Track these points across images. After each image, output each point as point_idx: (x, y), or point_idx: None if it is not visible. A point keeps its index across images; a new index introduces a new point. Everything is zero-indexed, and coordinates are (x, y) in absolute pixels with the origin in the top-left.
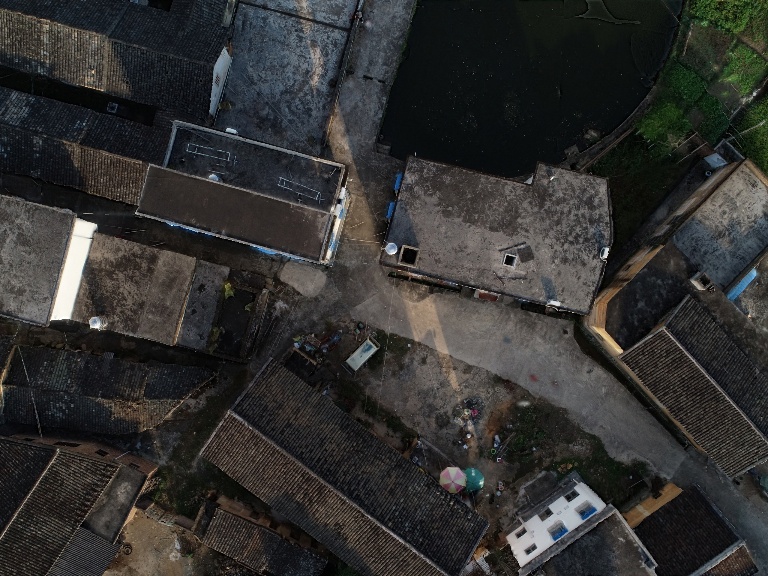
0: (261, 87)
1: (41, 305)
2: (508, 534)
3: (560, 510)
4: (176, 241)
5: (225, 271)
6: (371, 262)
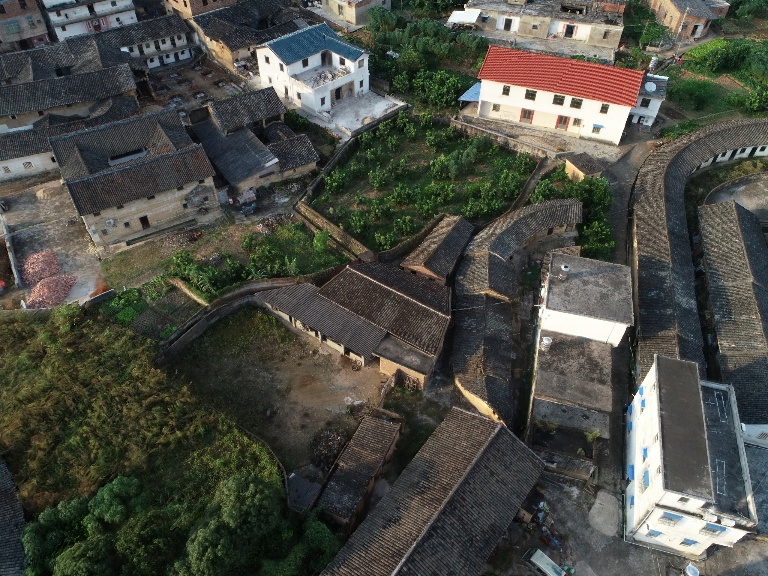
0: None
1: (561, 305)
2: None
3: None
4: None
5: (605, 435)
6: None
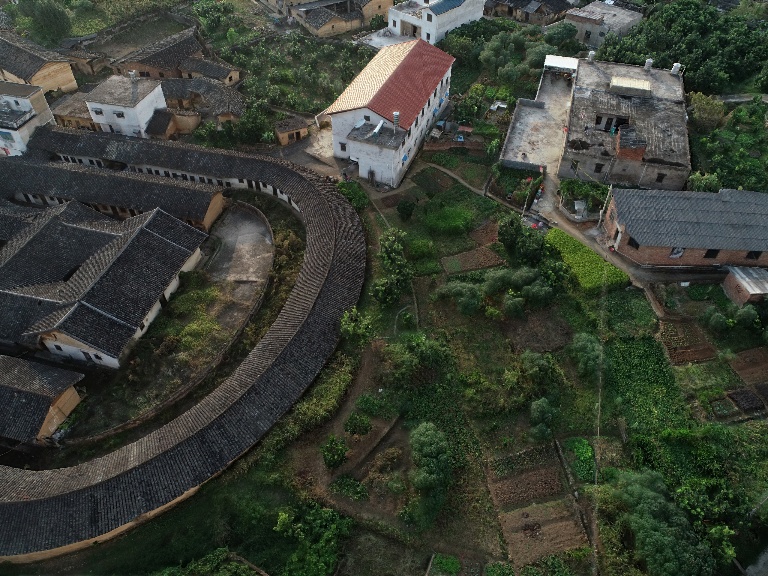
0: None
1: (112, 79)
2: None
3: None
4: None
5: None
6: None
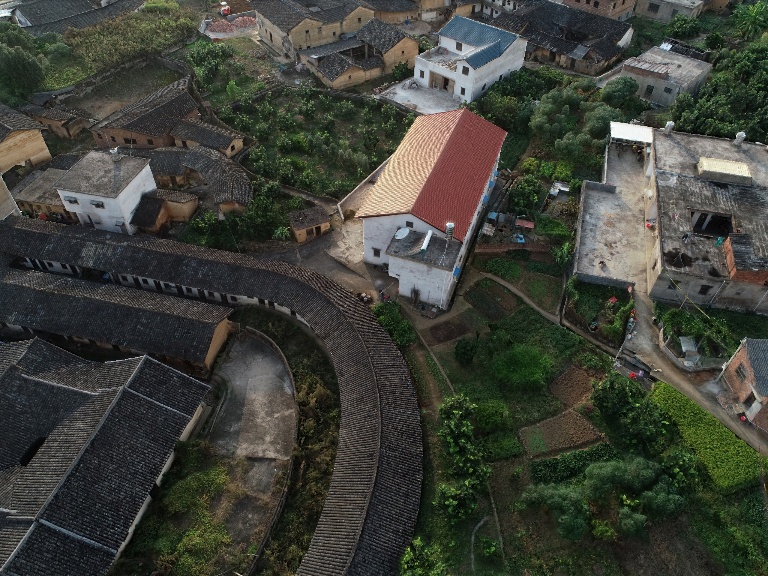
0: None
1: (90, 157)
2: None
3: None
4: None
5: None
6: None
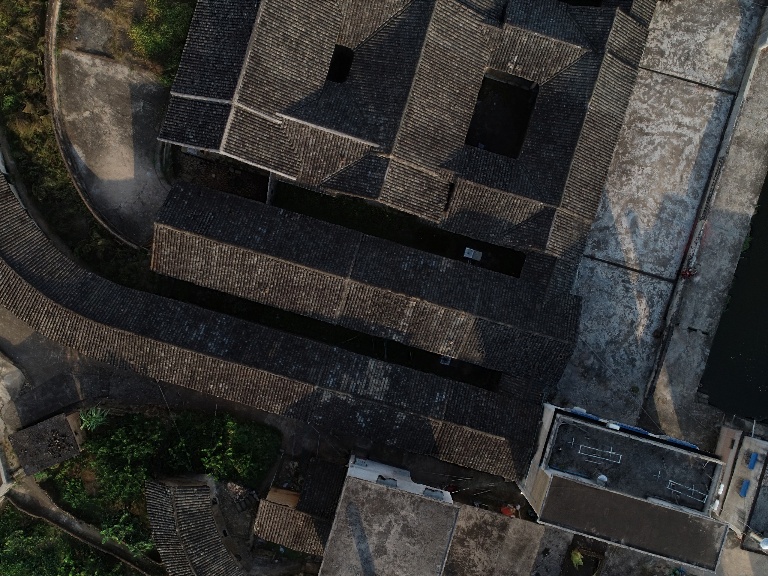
0: (587, 337)
1: None
2: None
3: None
4: (501, 489)
5: (569, 536)
6: None
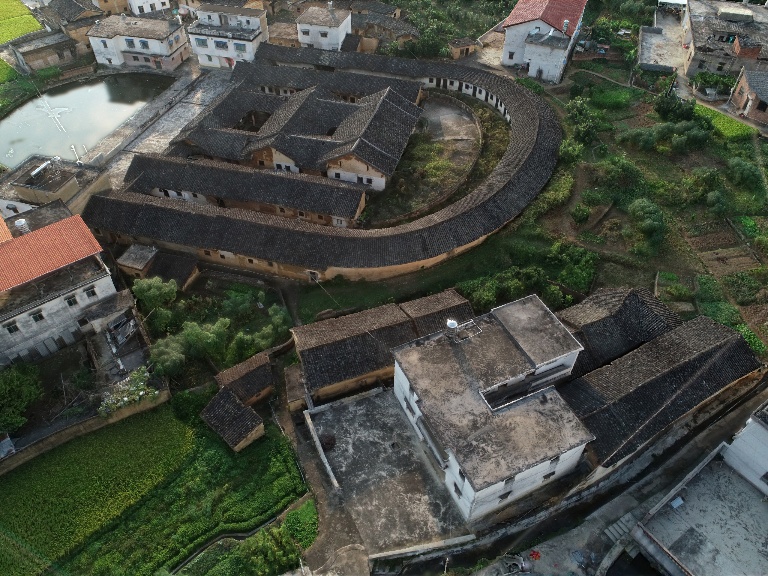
0: None
1: None
2: (169, 8)
3: (147, 3)
4: None
5: None
6: (196, 55)
